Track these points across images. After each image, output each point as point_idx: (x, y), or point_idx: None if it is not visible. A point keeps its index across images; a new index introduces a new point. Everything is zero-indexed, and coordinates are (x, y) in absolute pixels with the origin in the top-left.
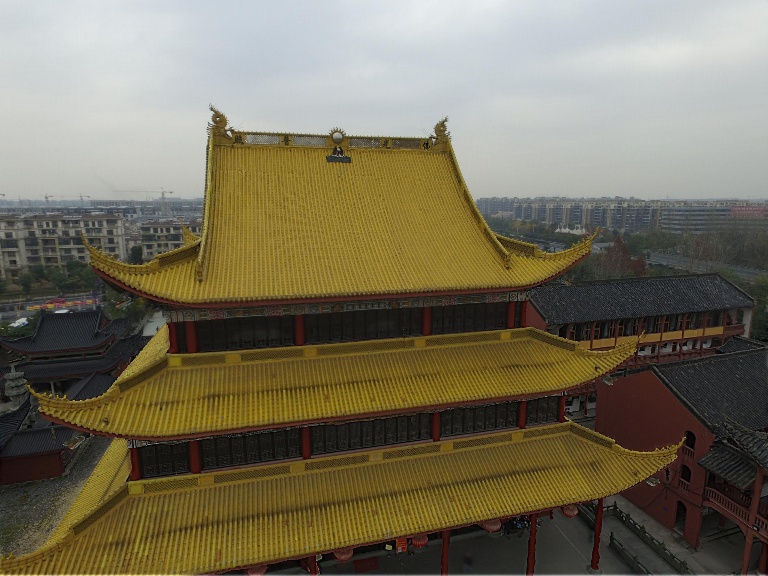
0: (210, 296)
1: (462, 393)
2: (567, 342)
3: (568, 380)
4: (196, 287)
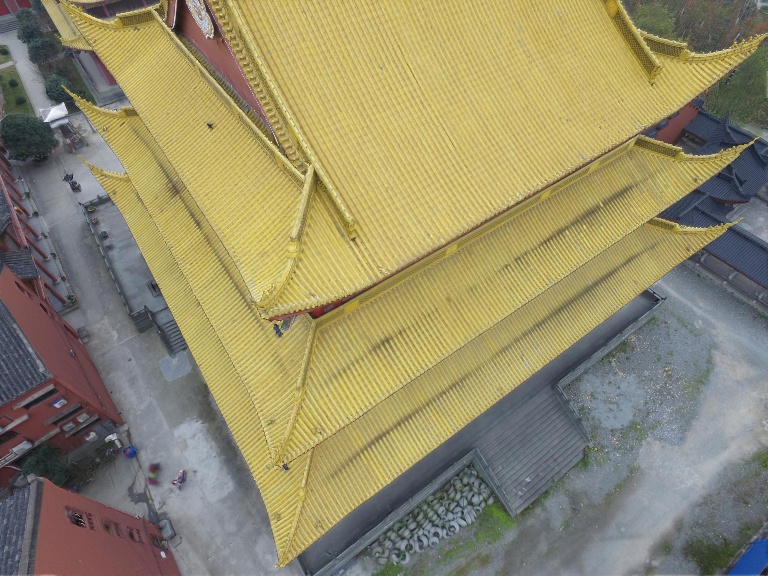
0: None
1: None
2: None
3: None
4: None
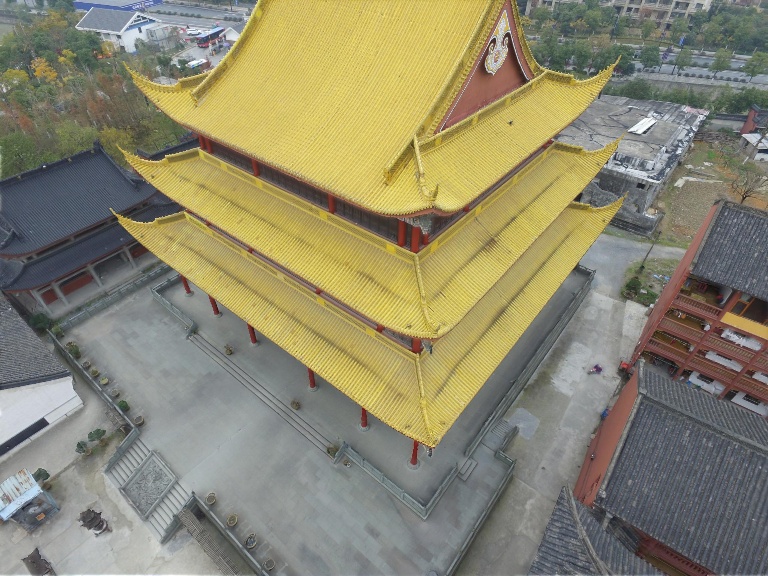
0: (189, 121)
1: (305, 270)
2: (420, 288)
3: (384, 317)
4: (190, 110)
